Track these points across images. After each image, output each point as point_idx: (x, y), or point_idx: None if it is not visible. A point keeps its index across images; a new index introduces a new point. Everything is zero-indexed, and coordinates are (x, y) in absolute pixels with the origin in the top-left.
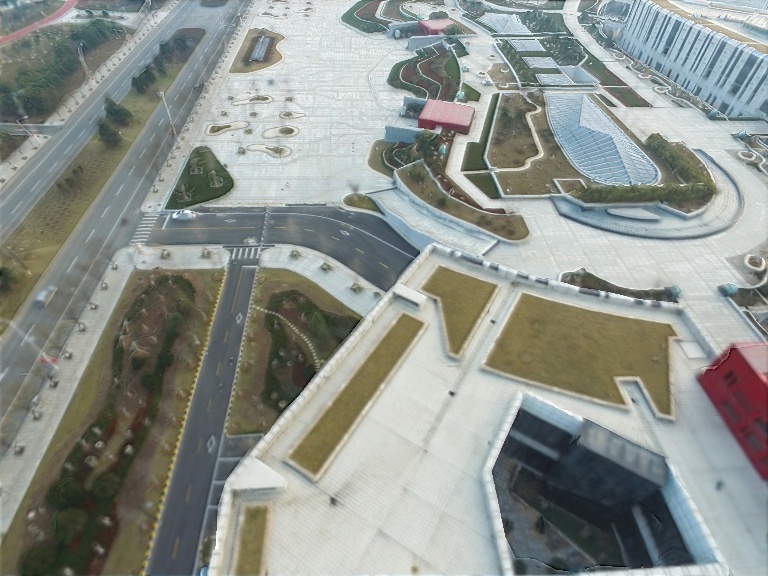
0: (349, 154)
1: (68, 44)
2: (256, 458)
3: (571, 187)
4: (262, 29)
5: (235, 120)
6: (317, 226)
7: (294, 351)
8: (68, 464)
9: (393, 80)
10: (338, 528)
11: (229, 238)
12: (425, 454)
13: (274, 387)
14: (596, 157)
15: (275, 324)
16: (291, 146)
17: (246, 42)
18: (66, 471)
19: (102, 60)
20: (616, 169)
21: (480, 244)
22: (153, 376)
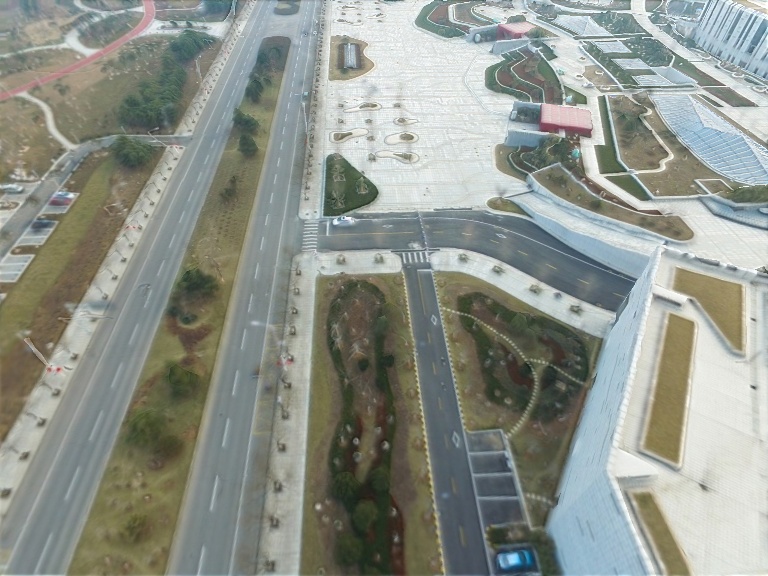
0: (475, 159)
1: (170, 55)
2: (620, 449)
3: (716, 187)
4: (344, 36)
5: (353, 127)
6: (472, 230)
7: (500, 351)
8: (336, 460)
9: (493, 84)
10: (723, 511)
11: (394, 243)
12: (762, 443)
13: (495, 385)
14: (730, 157)
15: (474, 325)
16: (417, 152)
17: (333, 49)
18: (334, 466)
19: (203, 70)
20: (753, 169)
21: (649, 245)
22: (379, 376)
